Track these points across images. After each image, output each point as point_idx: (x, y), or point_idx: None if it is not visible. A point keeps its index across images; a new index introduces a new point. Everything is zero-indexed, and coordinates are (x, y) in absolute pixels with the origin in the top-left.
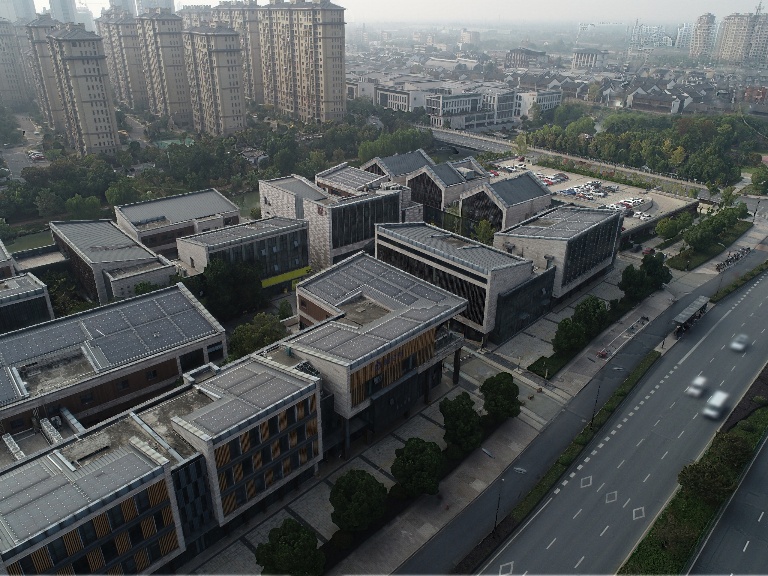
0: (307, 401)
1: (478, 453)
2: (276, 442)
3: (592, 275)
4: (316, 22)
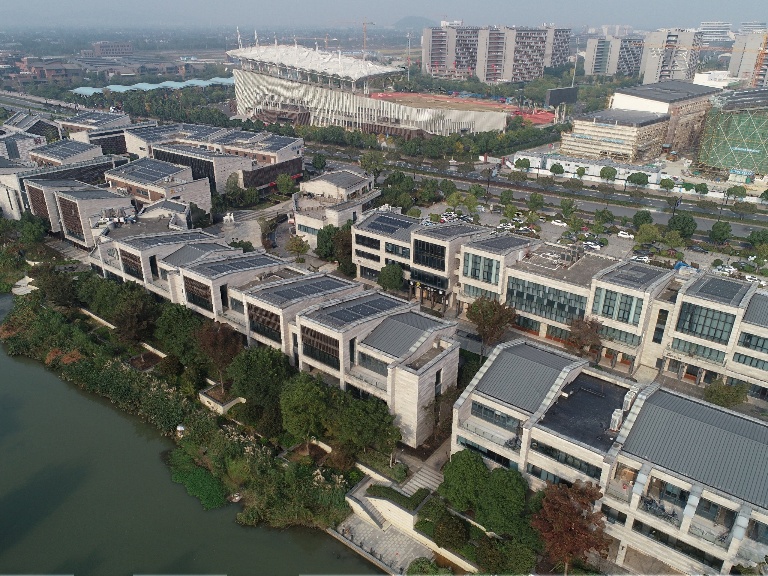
0: None
1: None
2: None
3: None
4: None
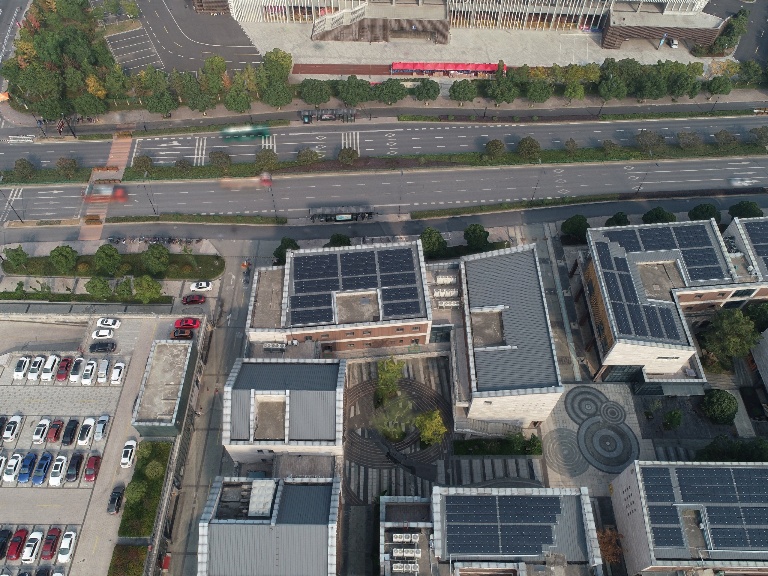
0: None
1: None
2: None
3: None
4: None
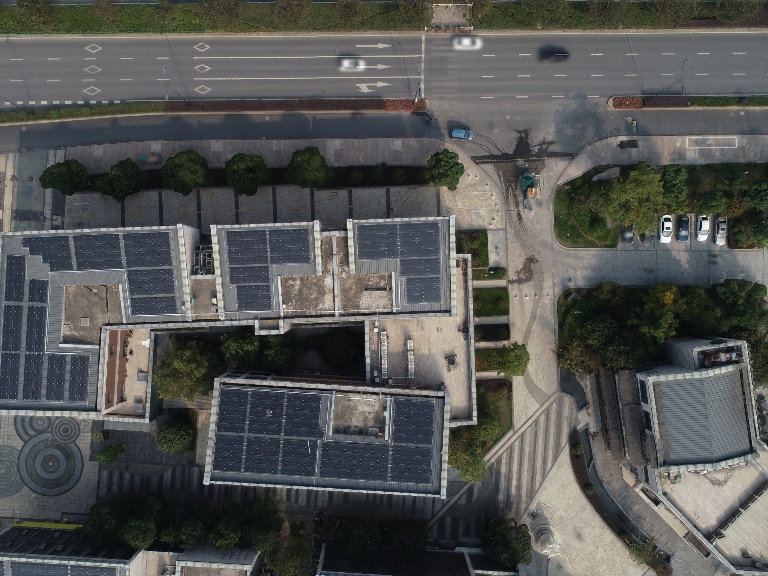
0: None
1: None
2: None
3: None
4: None
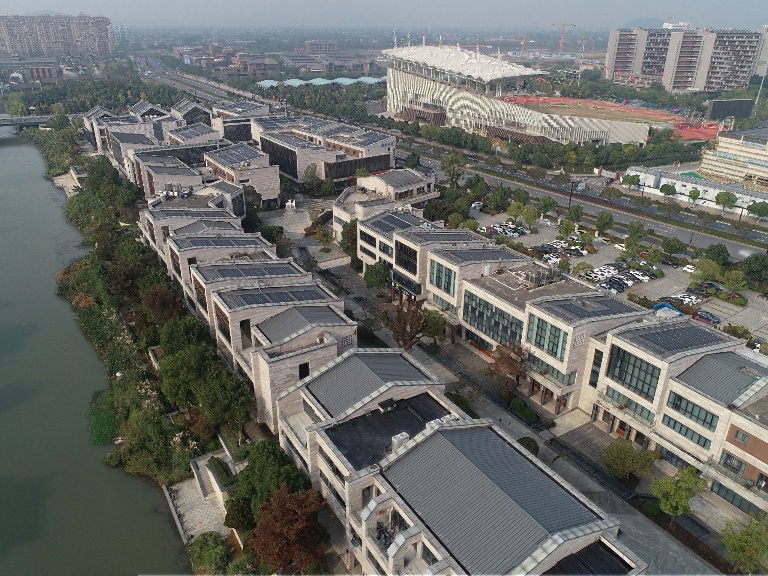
0: None
1: None
2: None
3: None
4: None
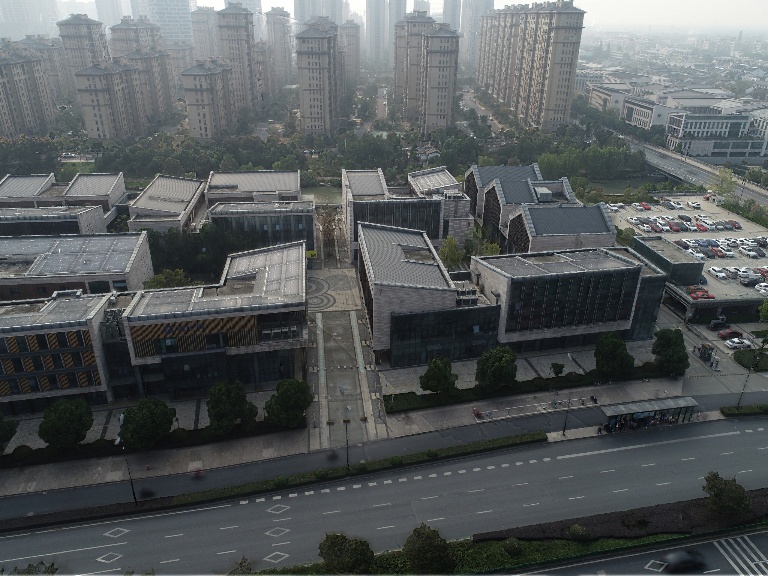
0: (81, 333)
1: (232, 443)
2: (48, 356)
3: (581, 333)
4: (551, 26)
